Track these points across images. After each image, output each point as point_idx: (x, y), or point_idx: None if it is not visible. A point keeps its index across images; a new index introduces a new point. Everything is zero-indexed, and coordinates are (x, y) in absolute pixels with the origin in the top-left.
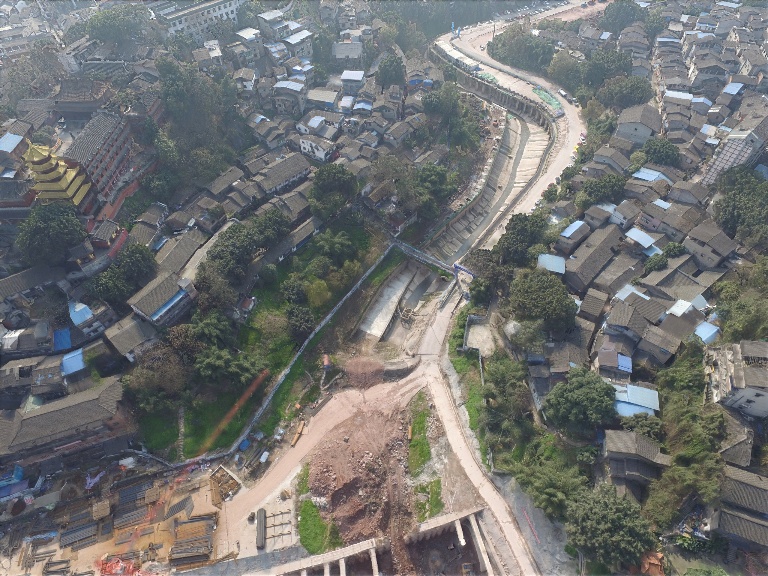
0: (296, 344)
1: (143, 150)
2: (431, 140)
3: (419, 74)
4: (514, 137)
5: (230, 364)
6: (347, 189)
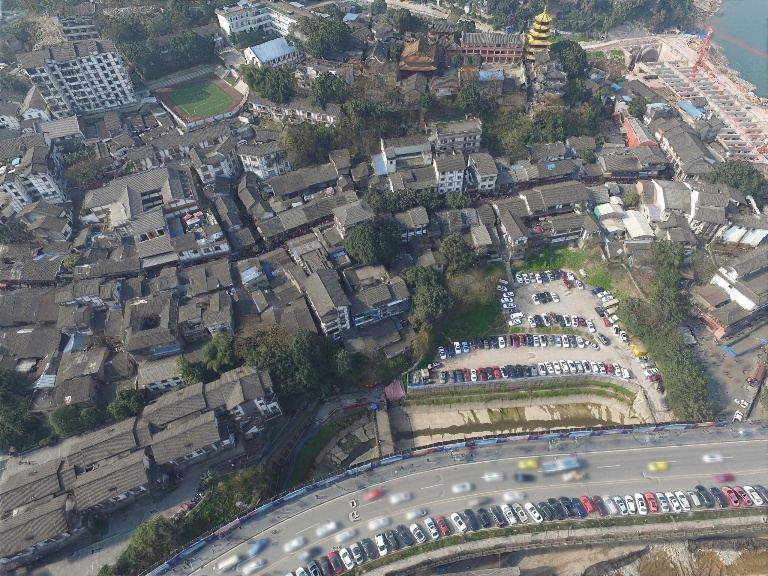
0: None
1: None
2: None
3: (345, 7)
4: None
5: None
6: None
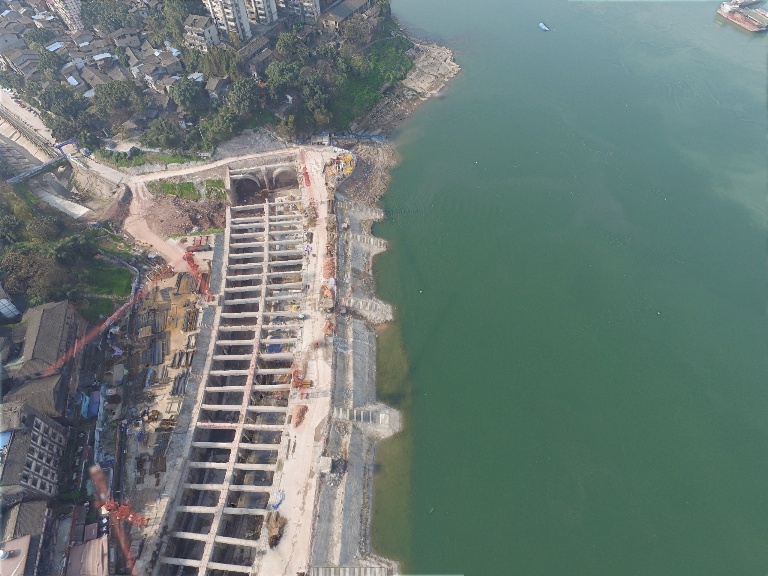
0: None
1: None
2: None
3: None
4: None
5: None
6: None
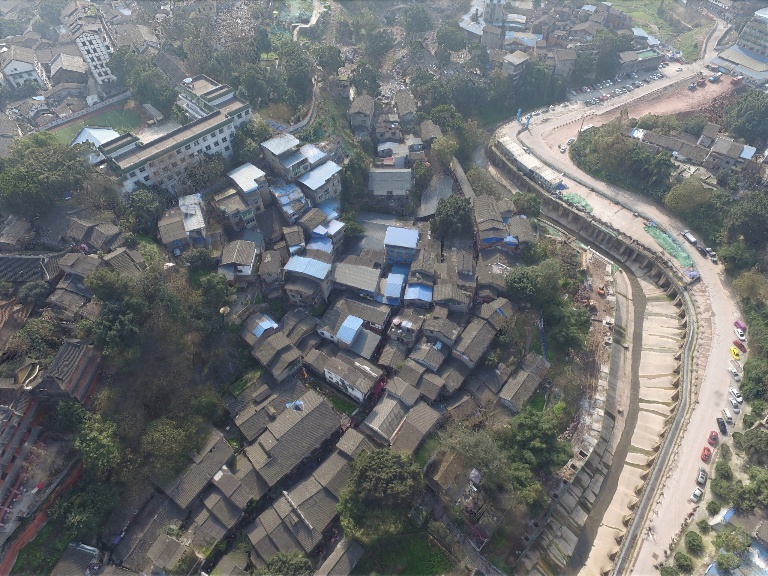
0: None
1: None
2: (522, 348)
3: (496, 227)
4: (625, 306)
5: None
6: None
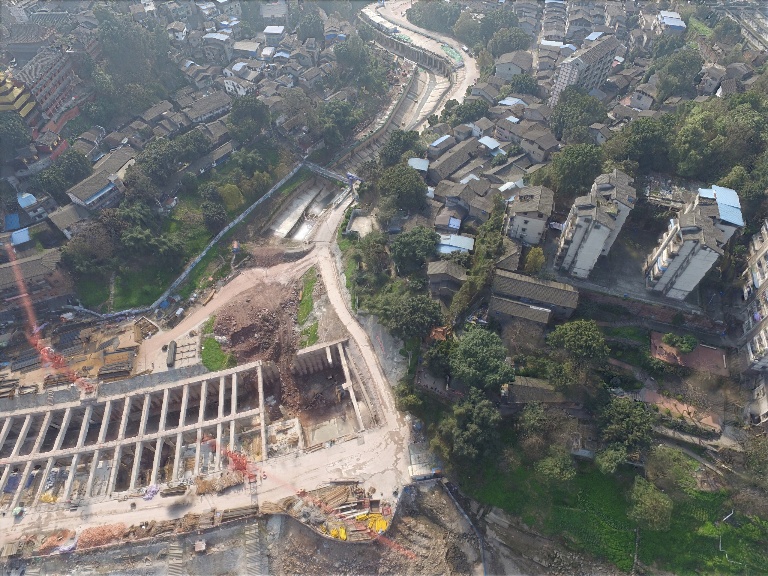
0: (212, 235)
1: (83, 83)
2: (341, 83)
3: (334, 30)
4: (422, 86)
5: (151, 239)
6: (260, 116)
